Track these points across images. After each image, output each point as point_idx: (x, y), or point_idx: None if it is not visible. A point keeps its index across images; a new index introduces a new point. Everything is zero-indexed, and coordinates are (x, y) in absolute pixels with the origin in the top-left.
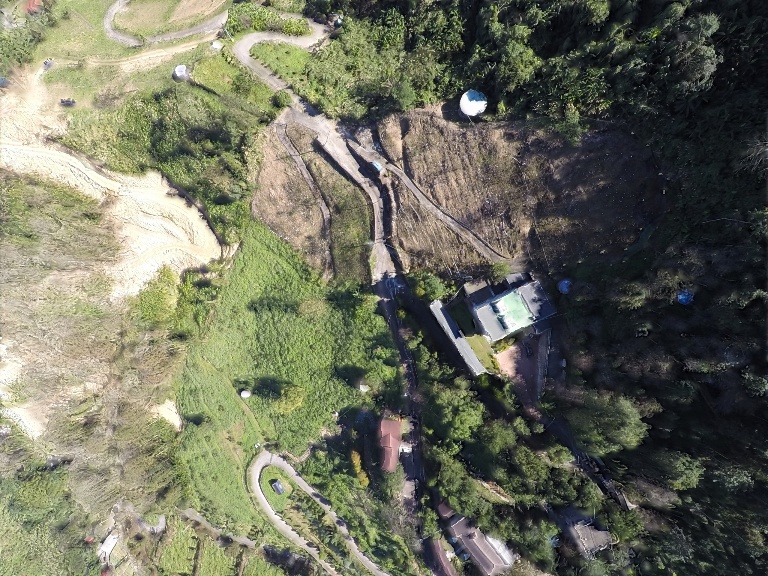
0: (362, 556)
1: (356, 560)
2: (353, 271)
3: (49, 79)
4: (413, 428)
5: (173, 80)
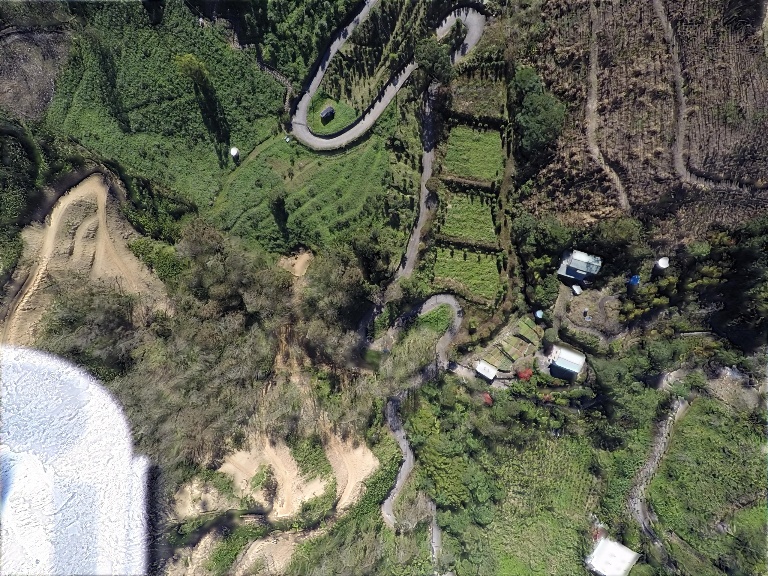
0: (371, 2)
1: (376, 8)
2: None
3: None
4: None
5: None
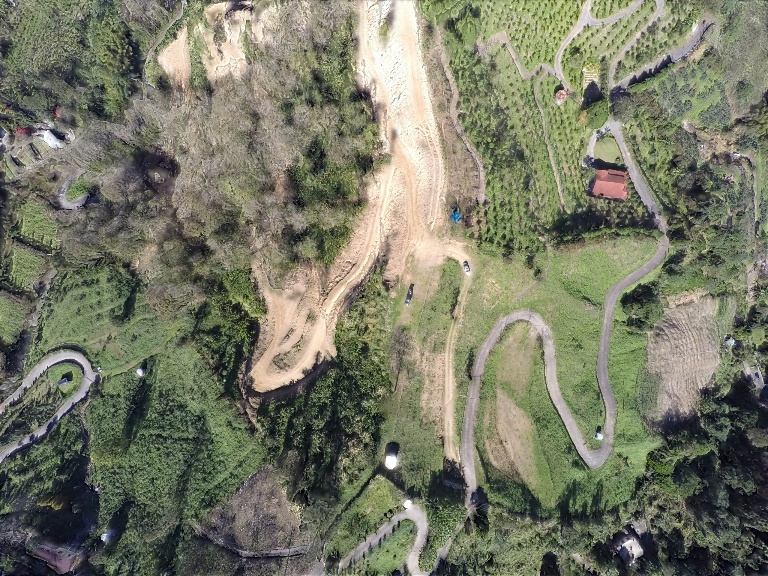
0: (6, 453)
1: (3, 448)
2: (187, 569)
3: (442, 270)
4: (71, 570)
5: (389, 442)
